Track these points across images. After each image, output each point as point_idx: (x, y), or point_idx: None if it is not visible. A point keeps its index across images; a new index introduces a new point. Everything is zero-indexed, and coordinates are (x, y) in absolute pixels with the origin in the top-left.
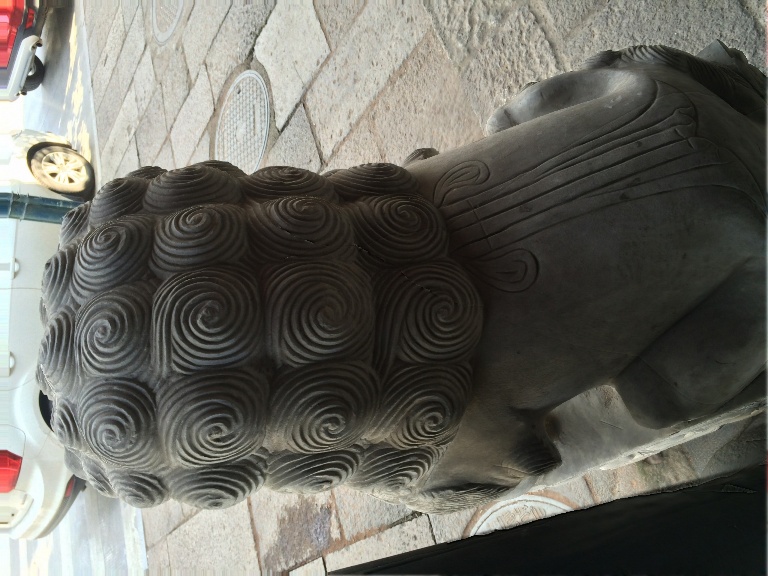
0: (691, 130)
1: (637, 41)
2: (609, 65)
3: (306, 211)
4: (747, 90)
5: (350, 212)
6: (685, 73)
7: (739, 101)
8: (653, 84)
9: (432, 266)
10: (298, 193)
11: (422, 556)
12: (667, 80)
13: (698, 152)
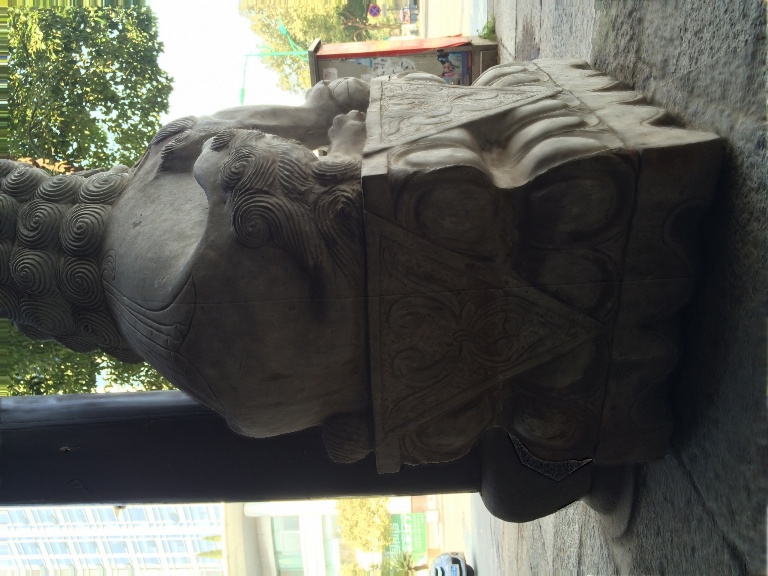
0: (175, 346)
1: None
2: (225, 193)
3: (22, 277)
4: (325, 275)
5: (56, 267)
6: (257, 248)
7: (316, 281)
8: (184, 282)
9: (92, 315)
10: (33, 245)
11: (90, 422)
12: (199, 280)
13: (174, 363)
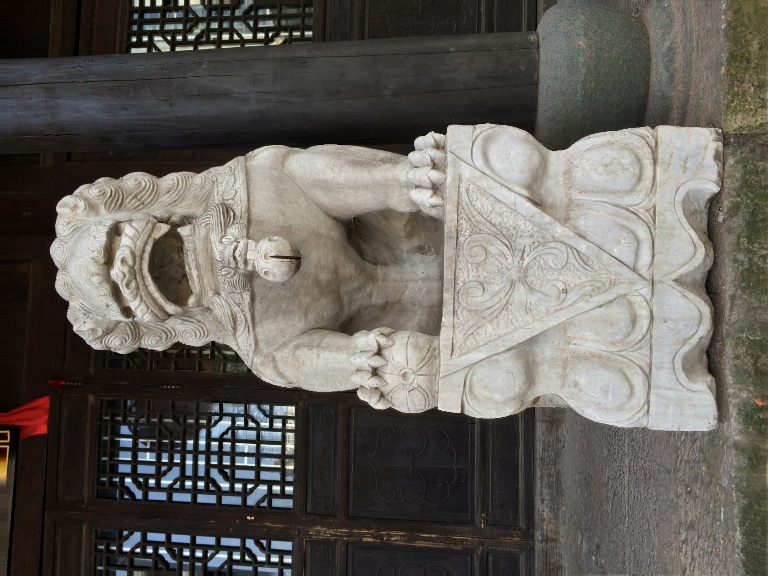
0: None
1: (650, 575)
2: None
3: None
4: None
5: None
6: None
7: None
8: None
9: None
10: None
11: None
12: None
13: None
